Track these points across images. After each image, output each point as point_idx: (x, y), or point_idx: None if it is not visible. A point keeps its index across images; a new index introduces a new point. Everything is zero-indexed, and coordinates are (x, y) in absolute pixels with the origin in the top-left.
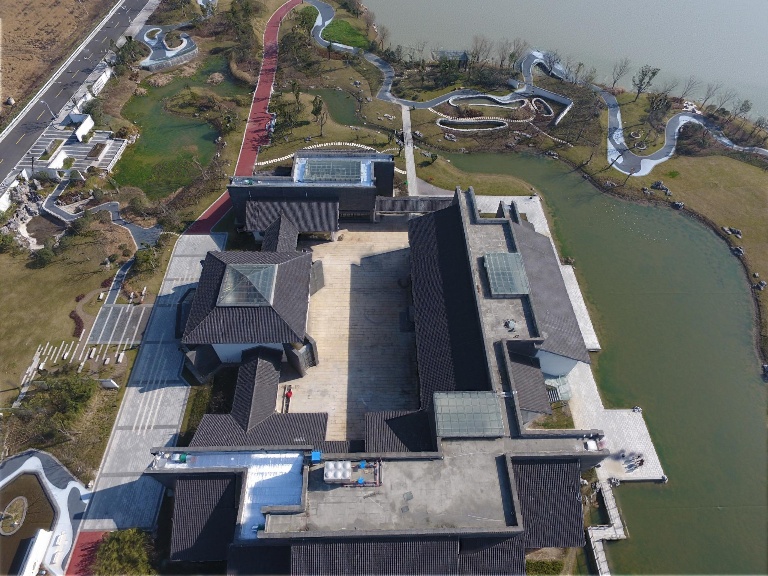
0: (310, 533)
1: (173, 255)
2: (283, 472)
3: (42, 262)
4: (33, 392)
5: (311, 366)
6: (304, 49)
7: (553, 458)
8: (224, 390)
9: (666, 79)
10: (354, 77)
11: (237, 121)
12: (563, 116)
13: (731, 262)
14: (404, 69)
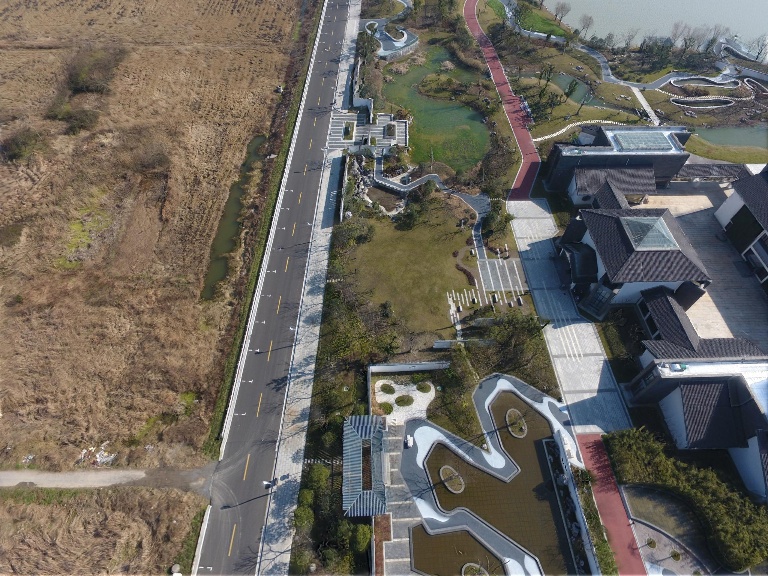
0: None
1: None
2: (766, 377)
3: (407, 225)
4: (467, 329)
5: None
6: None
7: None
8: (625, 325)
9: None
10: (574, 63)
11: (494, 103)
12: None
13: None
14: (612, 55)
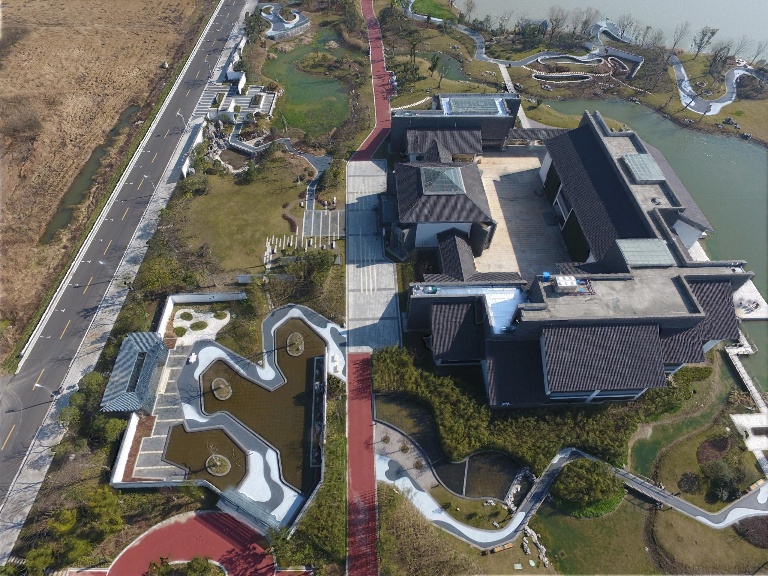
0: (558, 318)
1: (347, 176)
2: (509, 298)
3: (246, 180)
4: (276, 268)
5: (485, 249)
6: (402, 21)
7: (712, 279)
8: None
9: (722, 38)
10: (451, 43)
11: (364, 77)
12: (637, 71)
13: None
14: (491, 36)
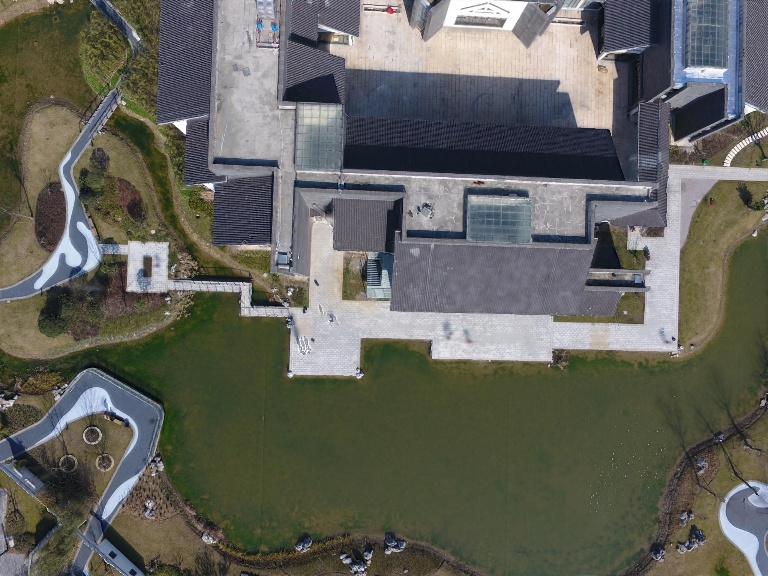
0: None
1: None
2: None
3: None
4: None
5: None
6: None
7: None
8: None
9: None
10: None
11: None
12: None
13: None
14: None
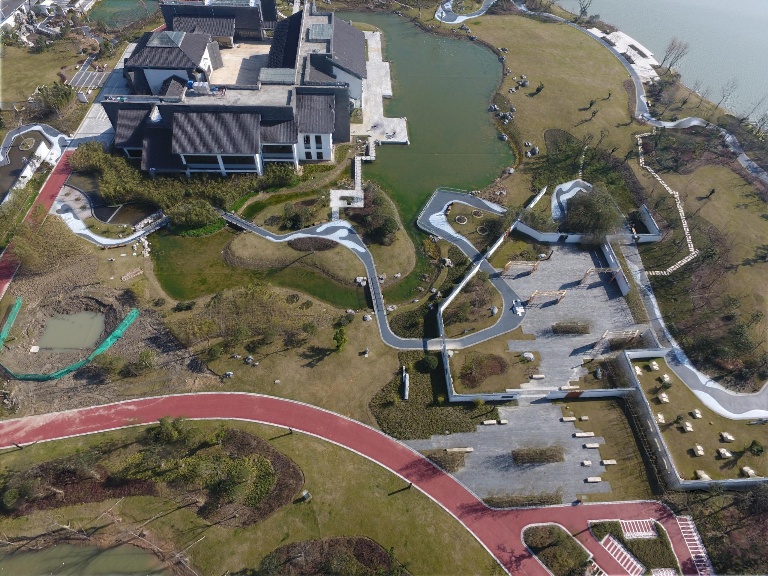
0: (183, 104)
1: (125, 52)
2: None
3: (38, 51)
4: None
5: None
6: None
7: (320, 92)
8: None
9: None
10: None
11: None
12: None
13: (496, 65)
14: None
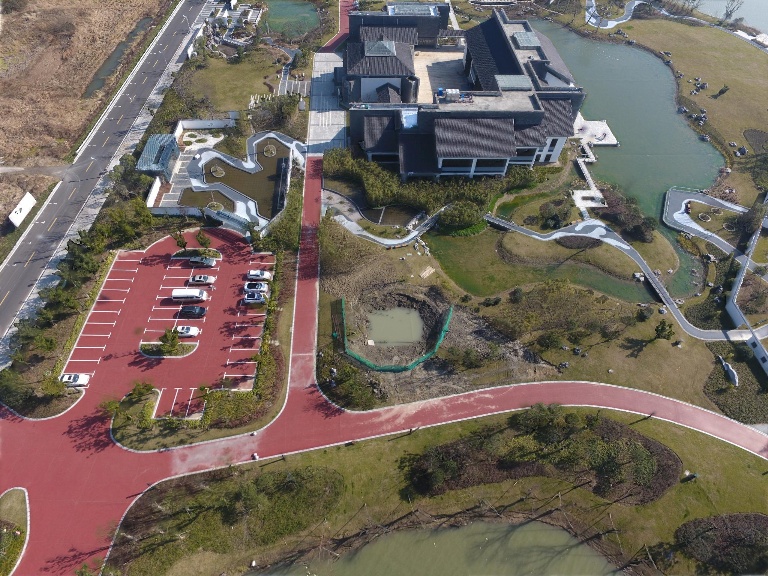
0: (444, 110)
1: (314, 61)
2: None
3: (237, 61)
4: None
5: None
6: None
7: (557, 97)
8: None
9: None
10: None
11: None
12: None
13: (664, 68)
14: None
